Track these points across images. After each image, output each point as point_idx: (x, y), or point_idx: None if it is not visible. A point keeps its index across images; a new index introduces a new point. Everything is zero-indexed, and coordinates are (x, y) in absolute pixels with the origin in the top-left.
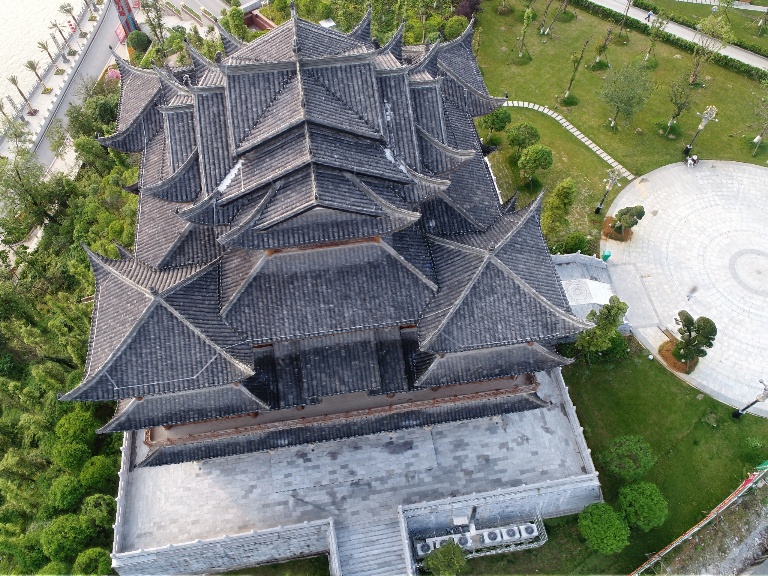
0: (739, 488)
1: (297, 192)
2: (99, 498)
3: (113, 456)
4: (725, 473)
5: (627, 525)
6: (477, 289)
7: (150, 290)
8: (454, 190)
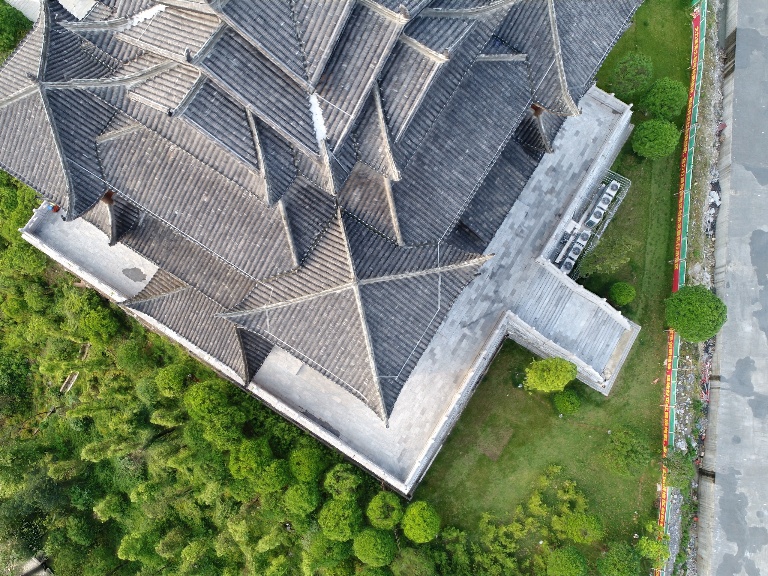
0: (695, 30)
1: (406, 71)
2: (334, 475)
3: (293, 445)
4: (678, 28)
5: (669, 122)
6: (561, 26)
7: (355, 282)
8: None
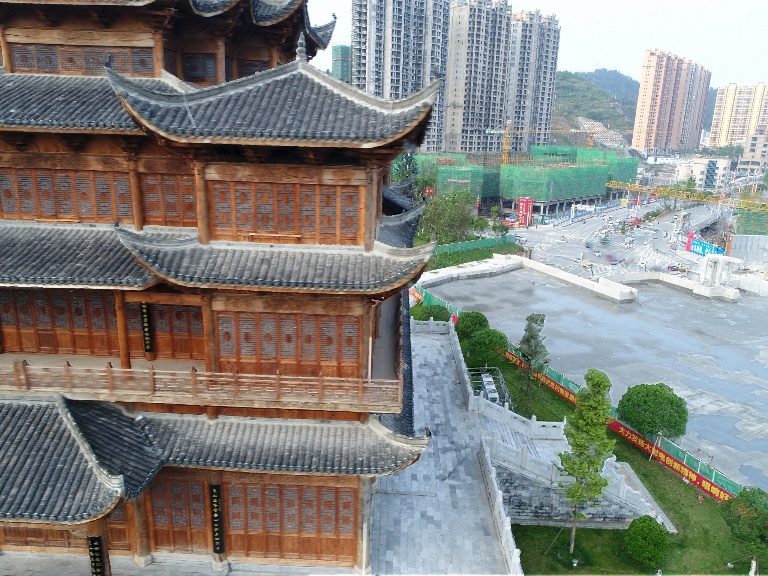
0: None
1: None
2: None
3: None
4: None
5: None
6: None
7: (303, 39)
8: None
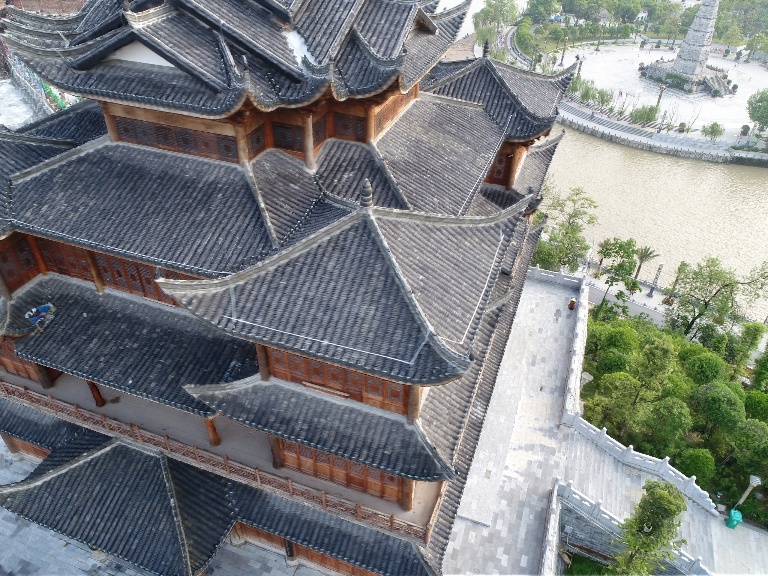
0: None
1: None
2: None
3: None
4: None
5: None
6: None
7: None
8: (90, 172)
